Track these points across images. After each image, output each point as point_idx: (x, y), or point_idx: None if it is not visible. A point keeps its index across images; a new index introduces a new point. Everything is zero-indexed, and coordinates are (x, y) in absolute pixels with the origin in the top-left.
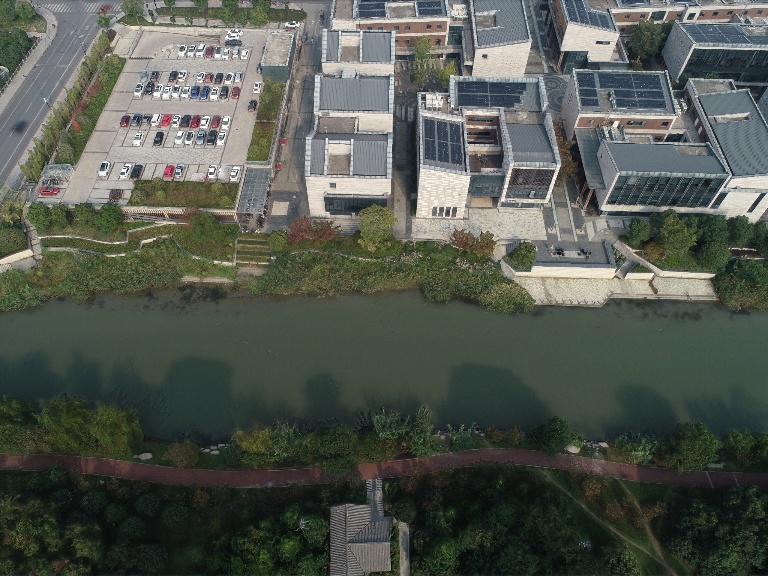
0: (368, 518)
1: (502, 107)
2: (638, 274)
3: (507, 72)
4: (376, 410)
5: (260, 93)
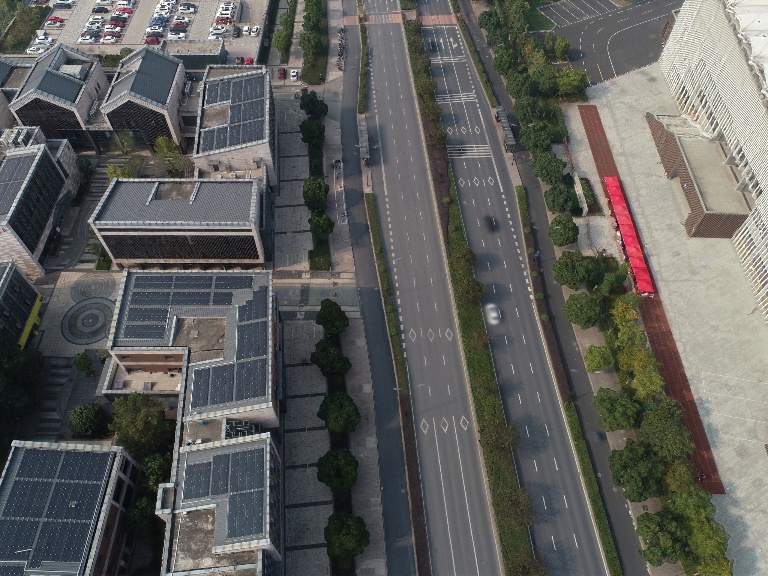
0: None
1: None
2: None
3: None
4: None
5: None
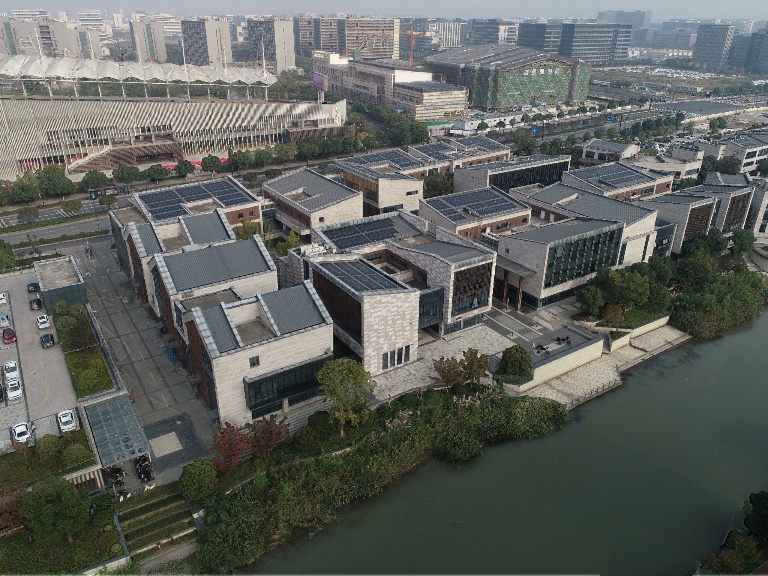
0: None
1: (385, 239)
2: (620, 340)
3: None
4: None
5: (50, 327)
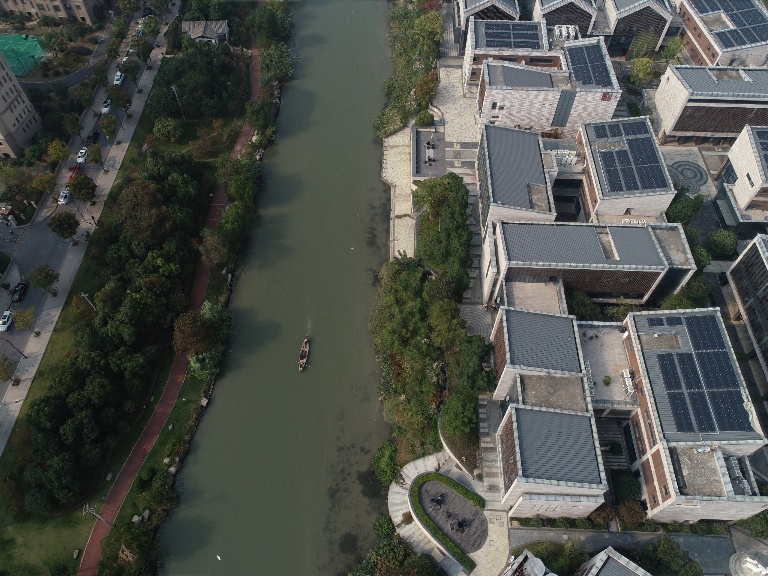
0: (219, 31)
1: (574, 74)
2: None
3: (667, 112)
4: (300, 61)
5: None
